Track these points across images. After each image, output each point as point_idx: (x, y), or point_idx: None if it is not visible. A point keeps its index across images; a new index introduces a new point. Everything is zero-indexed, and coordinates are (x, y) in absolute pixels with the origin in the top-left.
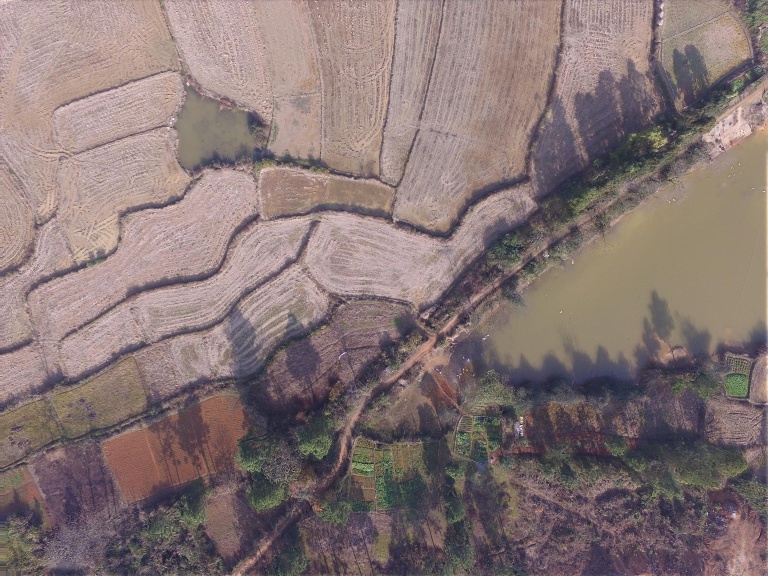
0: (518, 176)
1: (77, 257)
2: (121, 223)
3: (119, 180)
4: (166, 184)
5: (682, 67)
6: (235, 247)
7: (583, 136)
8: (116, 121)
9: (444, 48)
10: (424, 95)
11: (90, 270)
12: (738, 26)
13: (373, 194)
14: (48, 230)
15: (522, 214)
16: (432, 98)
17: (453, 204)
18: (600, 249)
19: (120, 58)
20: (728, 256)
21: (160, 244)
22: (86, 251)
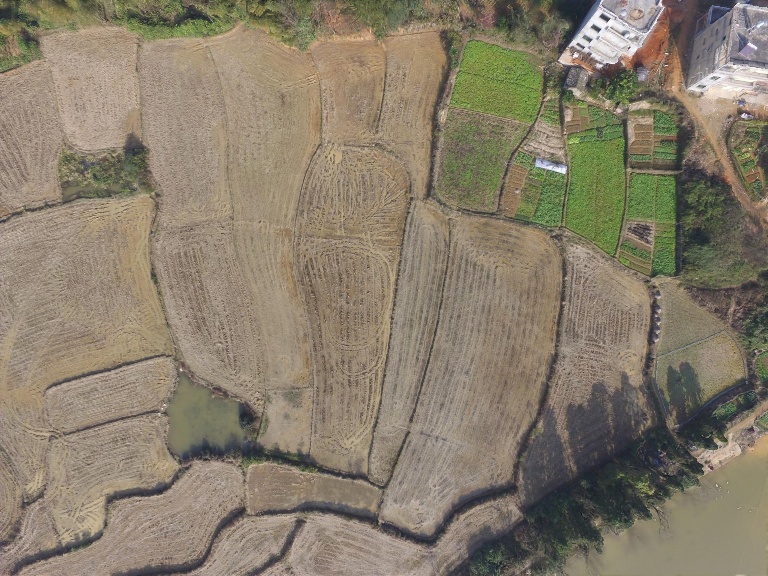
0: (506, 483)
1: (63, 538)
2: (108, 509)
3: (108, 463)
4: (154, 470)
5: (676, 384)
6: (220, 541)
7: (573, 447)
8: (108, 403)
9: (439, 351)
10: (416, 397)
11: (75, 554)
12: (734, 345)
13: (360, 494)
14: (35, 510)
15: (507, 523)
16: (424, 401)
17: (439, 508)
18: (583, 568)
19: (114, 340)
20: (711, 575)
21: (146, 532)
22: (72, 532)
